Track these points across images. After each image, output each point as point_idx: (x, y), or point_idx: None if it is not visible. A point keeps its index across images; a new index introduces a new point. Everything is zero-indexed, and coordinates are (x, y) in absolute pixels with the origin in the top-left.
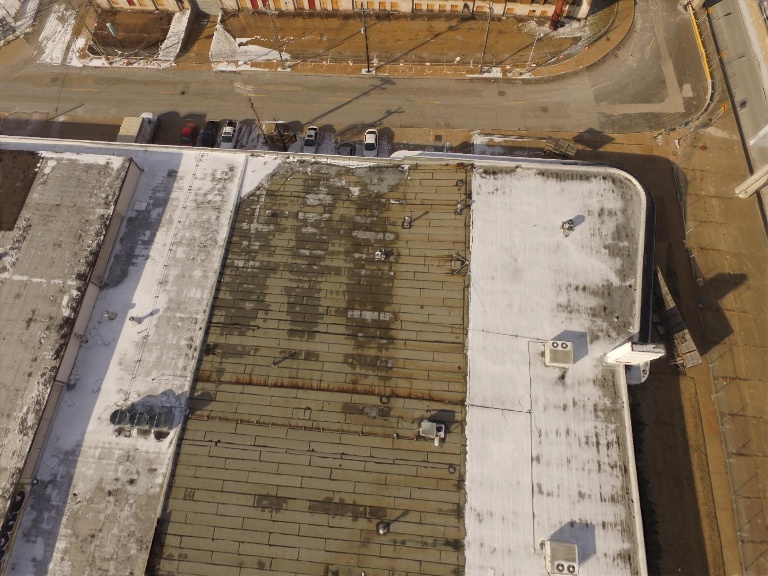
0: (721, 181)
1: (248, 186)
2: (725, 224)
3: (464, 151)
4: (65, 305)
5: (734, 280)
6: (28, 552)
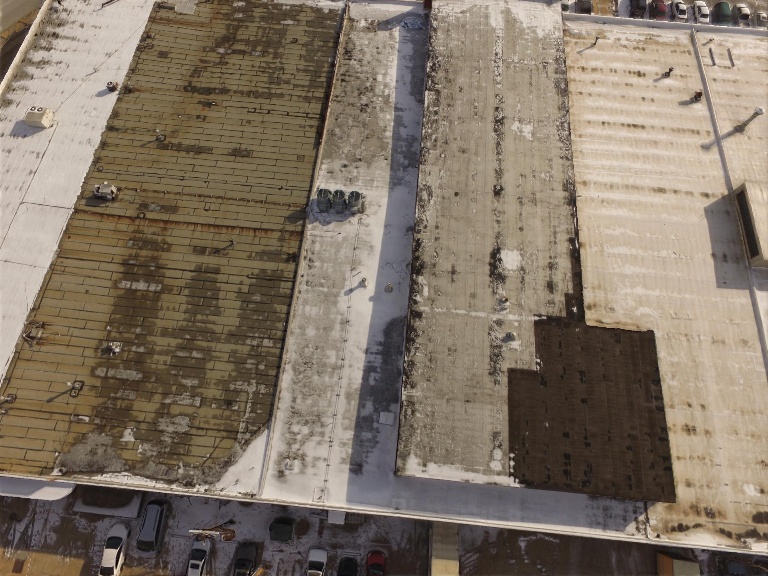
0: None
1: (259, 446)
2: None
3: None
4: (424, 286)
5: None
6: (411, 131)
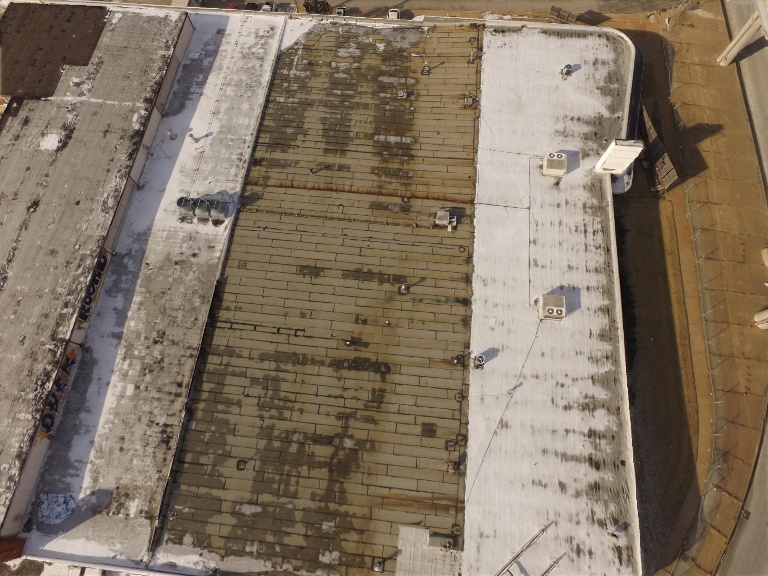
0: (705, 52)
1: (287, 42)
2: (706, 86)
3: None
4: (135, 121)
5: (711, 129)
6: (110, 303)
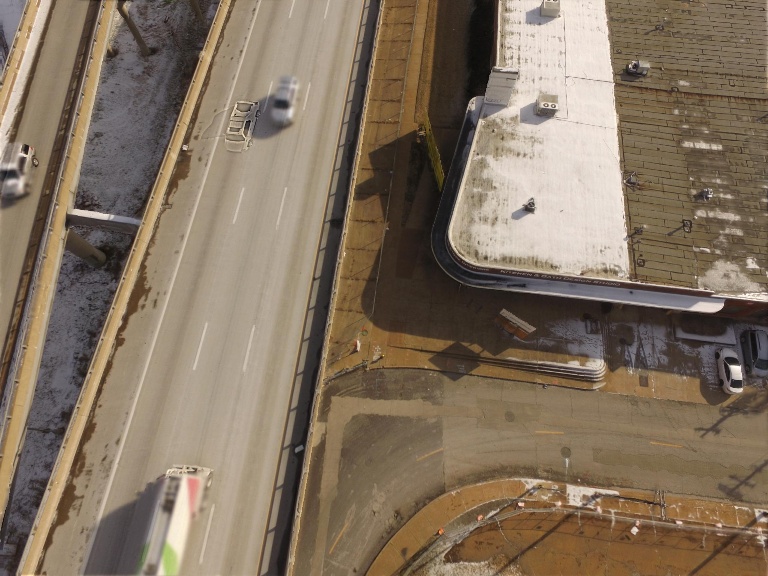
0: None
1: None
2: None
3: (611, 356)
4: None
5: None
6: None
